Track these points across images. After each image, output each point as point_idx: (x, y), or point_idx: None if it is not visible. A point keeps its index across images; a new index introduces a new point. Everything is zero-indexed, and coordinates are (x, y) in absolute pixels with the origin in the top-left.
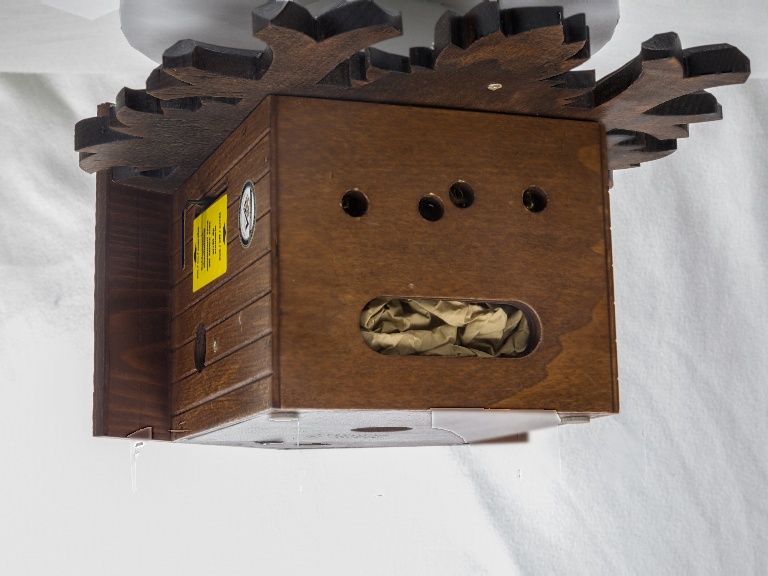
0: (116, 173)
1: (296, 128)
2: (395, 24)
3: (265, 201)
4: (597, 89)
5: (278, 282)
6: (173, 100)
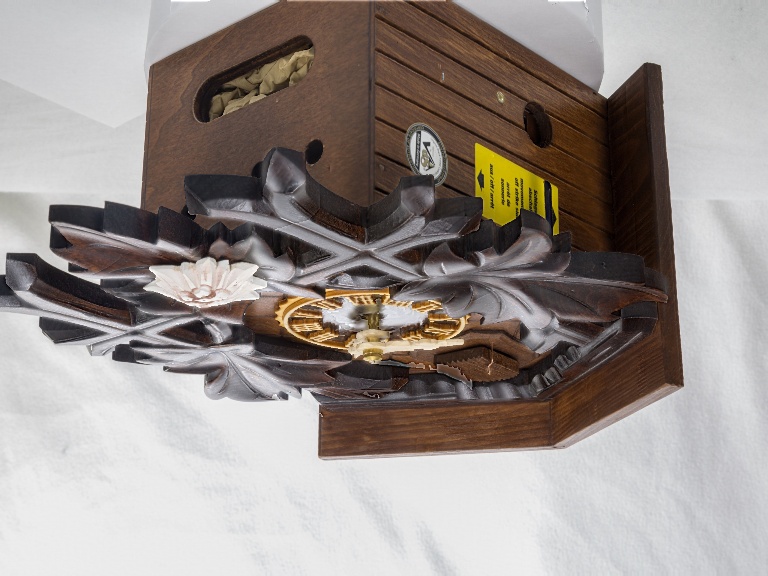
0: (652, 309)
1: (355, 200)
2: None
3: (385, 132)
4: (122, 307)
5: (370, 59)
6: (482, 230)
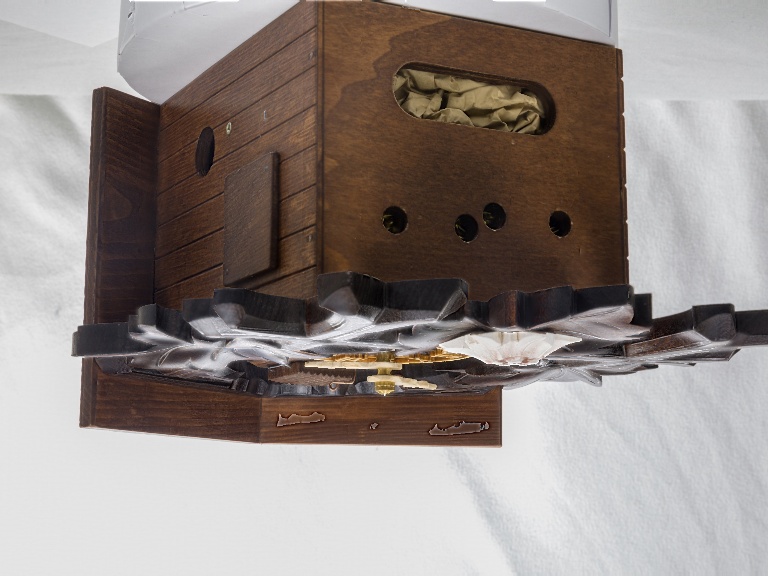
0: None
1: None
2: (714, 308)
3: None
4: None
5: (620, 156)
6: None
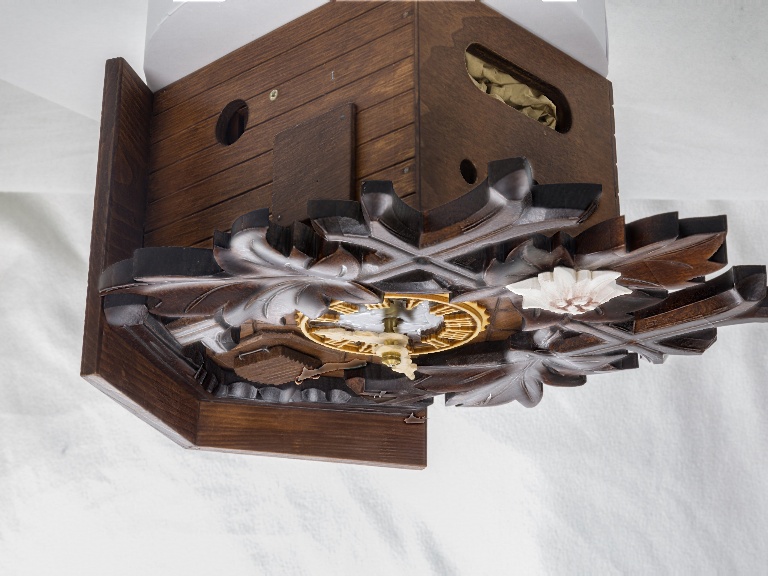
0: None
1: None
2: (752, 268)
3: None
4: None
5: (614, 169)
6: None
